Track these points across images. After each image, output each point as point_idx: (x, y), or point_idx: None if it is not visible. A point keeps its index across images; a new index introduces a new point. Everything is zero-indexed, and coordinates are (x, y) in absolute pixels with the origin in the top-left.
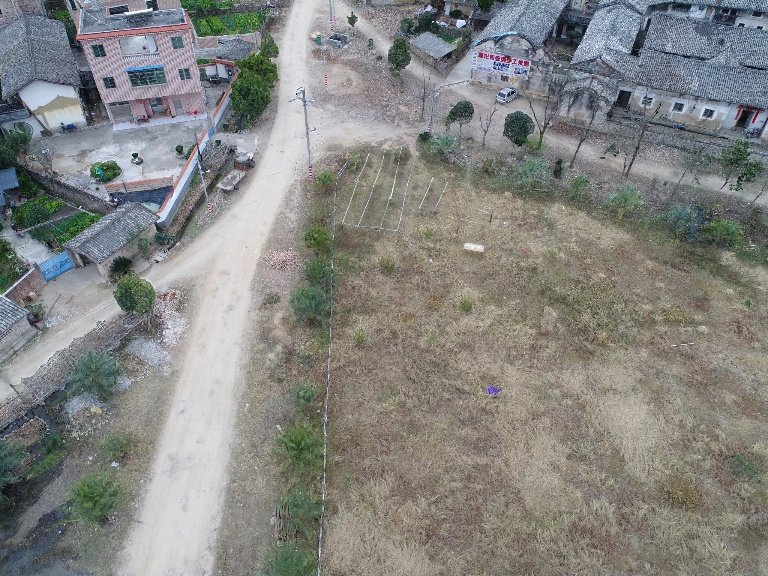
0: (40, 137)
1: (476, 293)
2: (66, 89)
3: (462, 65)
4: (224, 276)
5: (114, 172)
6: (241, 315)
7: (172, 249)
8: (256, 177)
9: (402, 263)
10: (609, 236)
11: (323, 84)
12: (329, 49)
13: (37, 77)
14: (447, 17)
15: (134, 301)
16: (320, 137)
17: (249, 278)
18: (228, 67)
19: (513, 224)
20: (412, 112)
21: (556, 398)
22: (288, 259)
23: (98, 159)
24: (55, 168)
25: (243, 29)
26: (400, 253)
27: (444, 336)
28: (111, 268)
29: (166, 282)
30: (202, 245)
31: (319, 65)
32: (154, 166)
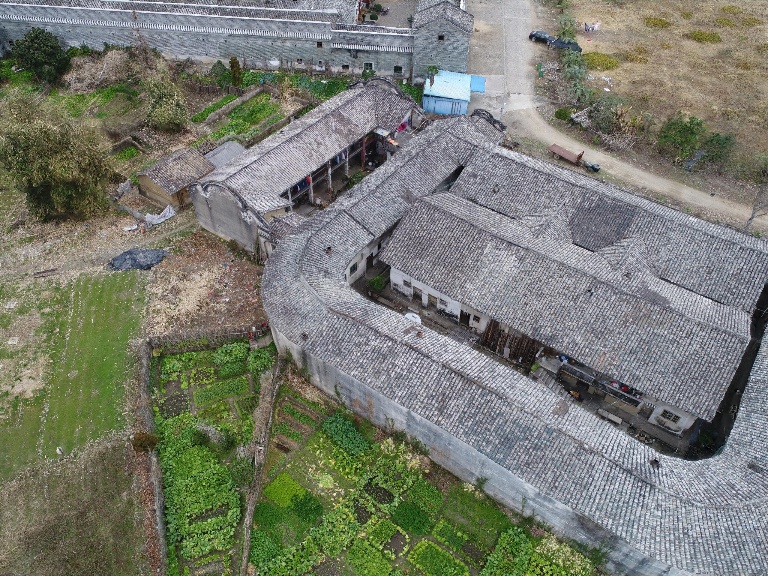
0: None
1: None
2: None
3: None
4: None
5: None
6: None
7: None
8: None
9: None
10: None
11: None
12: None
13: None
14: None
15: None
16: None
17: None
18: None
19: None
20: None
21: None
22: None
23: None
24: None
25: None
26: None
27: None
28: None
29: None
30: None
31: None
32: None
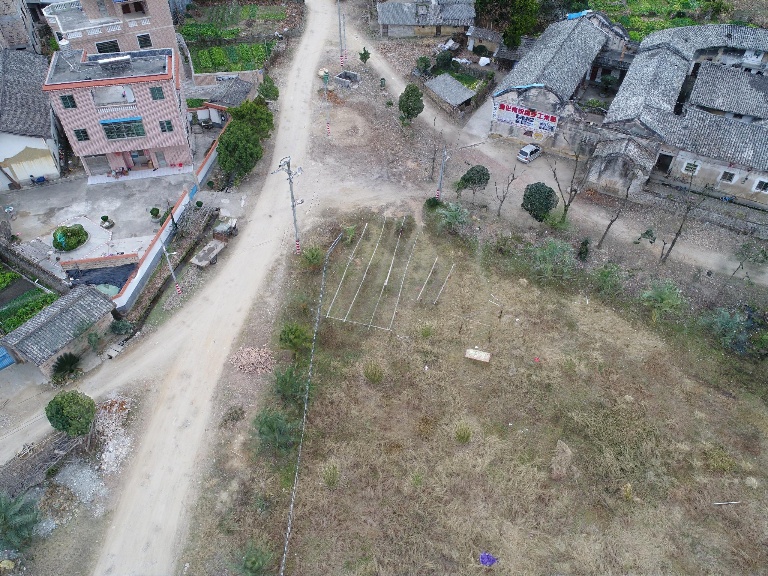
0: (8, 190)
1: (476, 416)
2: (35, 140)
3: (482, 112)
4: (184, 380)
5: (79, 239)
6: (197, 435)
7: (130, 341)
8: (237, 248)
9: (392, 370)
10: (640, 343)
11: (325, 132)
12: (337, 89)
13: (1, 129)
14: (470, 53)
15: (67, 422)
16: (315, 199)
17: (212, 384)
18: (221, 112)
19: (527, 322)
20: (421, 170)
21: (565, 575)
22: (259, 361)
23: (65, 220)
24: (17, 230)
25: (246, 63)
26: (391, 357)
27: (433, 477)
28: (54, 367)
29: (117, 385)
30: (165, 336)
31: (324, 108)
32: (125, 231)
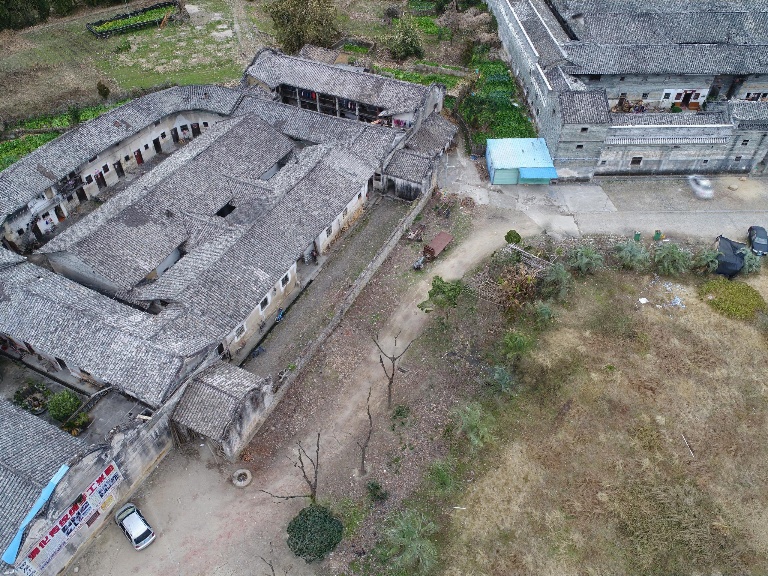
0: None
1: None
2: None
3: None
4: None
5: None
6: None
7: None
8: None
9: None
10: (520, 466)
11: None
12: None
13: None
14: None
15: None
16: None
17: None
18: None
19: None
20: None
21: None
22: None
23: None
24: None
25: None
26: None
27: None
28: None
29: None
30: None
31: None
32: None
